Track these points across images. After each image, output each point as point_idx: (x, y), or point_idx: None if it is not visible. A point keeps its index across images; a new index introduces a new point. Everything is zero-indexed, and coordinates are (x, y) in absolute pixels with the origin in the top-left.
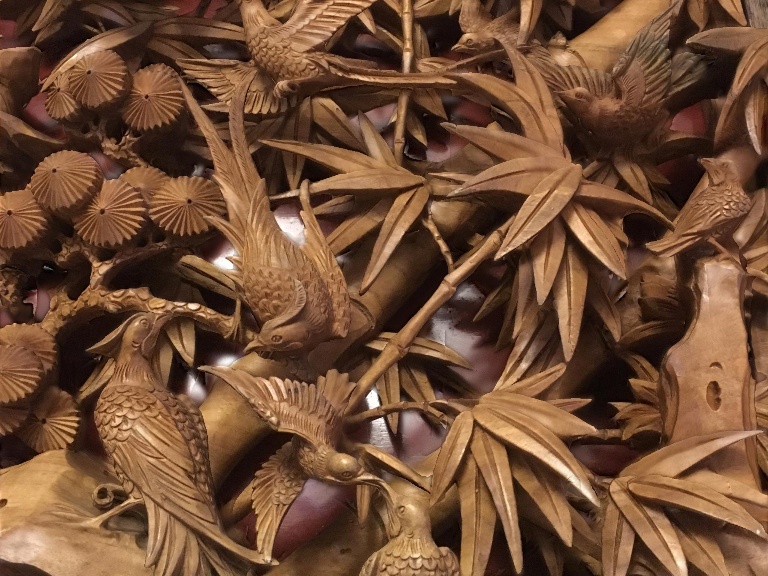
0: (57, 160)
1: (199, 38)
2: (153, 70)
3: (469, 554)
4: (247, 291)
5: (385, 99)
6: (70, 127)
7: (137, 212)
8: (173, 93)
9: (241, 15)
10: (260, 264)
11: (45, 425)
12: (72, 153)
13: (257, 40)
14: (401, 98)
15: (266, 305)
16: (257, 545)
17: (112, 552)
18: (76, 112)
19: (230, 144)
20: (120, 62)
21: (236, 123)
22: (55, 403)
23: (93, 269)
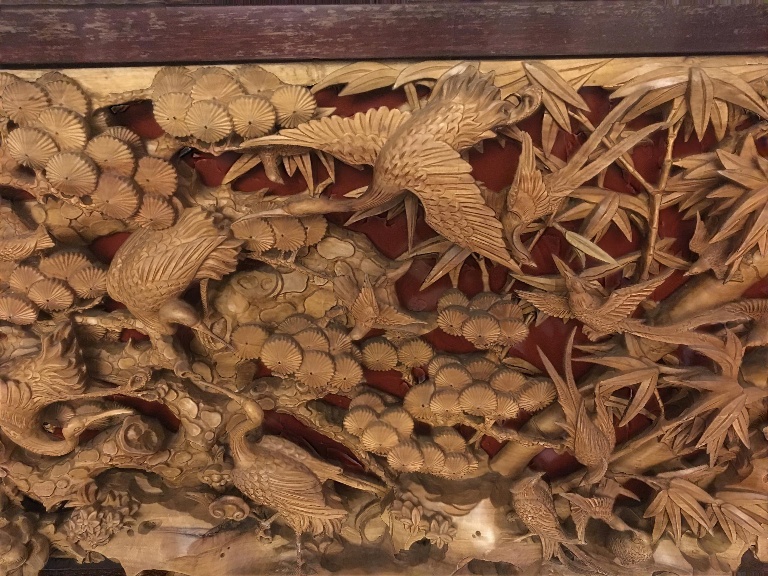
0: (476, 399)
1: None
2: (506, 309)
3: (657, 534)
4: (577, 456)
5: None
6: None
7: None
8: (523, 332)
9: (570, 294)
10: (586, 451)
11: None
12: (482, 391)
13: None
14: None
15: None
16: (578, 538)
17: (526, 548)
18: None
19: (565, 380)
20: (497, 327)
21: (568, 368)
22: None
23: (487, 422)
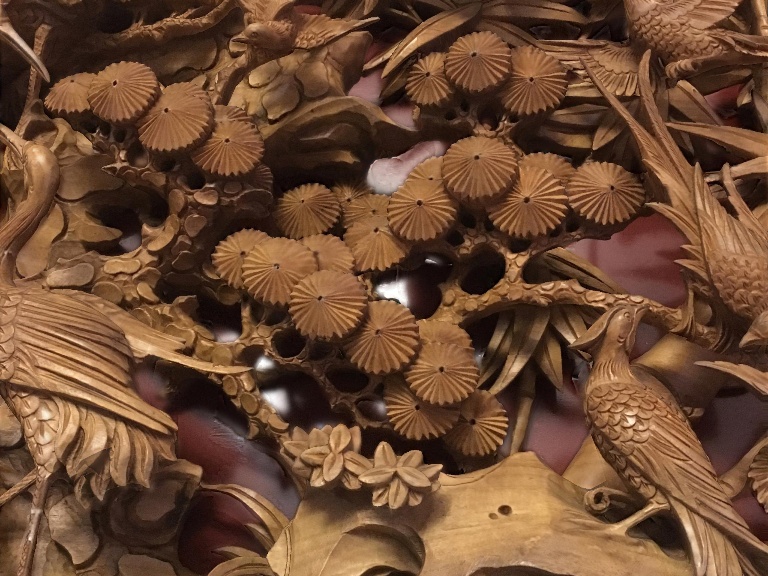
0: (473, 146)
1: (529, 19)
2: (523, 52)
3: None
4: (717, 281)
5: (734, 80)
6: (431, 113)
7: (561, 200)
8: (557, 75)
9: None
10: (732, 252)
11: (474, 426)
12: (483, 139)
13: (648, 17)
14: (767, 78)
15: (743, 296)
16: None
17: (646, 561)
18: (448, 97)
19: (650, 127)
20: (503, 43)
21: (650, 105)
22: (479, 403)
23: (509, 261)
